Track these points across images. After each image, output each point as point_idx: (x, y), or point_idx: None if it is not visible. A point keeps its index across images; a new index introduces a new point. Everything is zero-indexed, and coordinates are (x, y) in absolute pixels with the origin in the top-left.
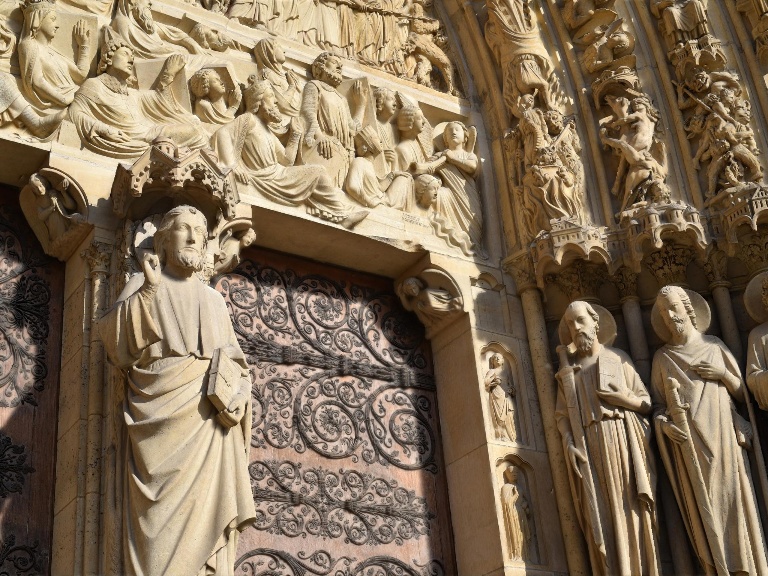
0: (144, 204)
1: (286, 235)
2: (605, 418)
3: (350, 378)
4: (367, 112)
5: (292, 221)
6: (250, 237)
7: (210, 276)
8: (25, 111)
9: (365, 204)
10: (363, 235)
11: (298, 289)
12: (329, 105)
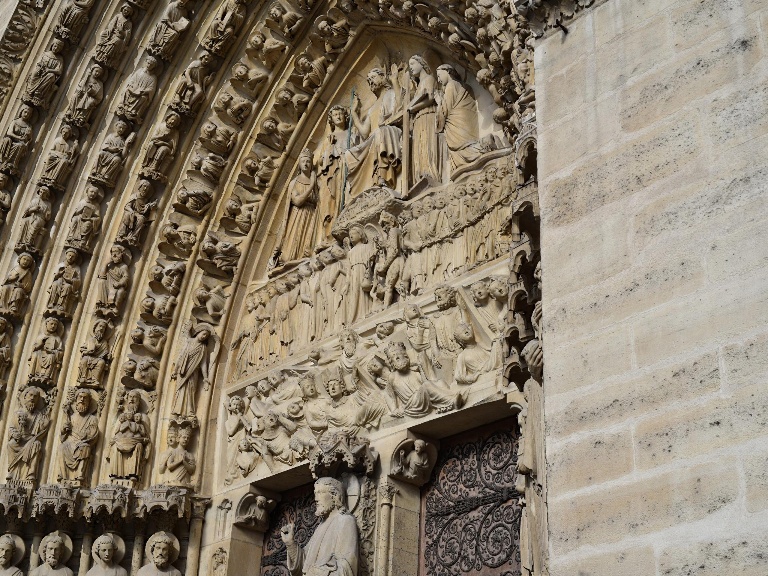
0: (350, 468)
1: (451, 426)
2: (522, 507)
3: (511, 501)
4: (468, 310)
5: (435, 422)
6: (417, 447)
7: (387, 490)
8: (310, 444)
9: (469, 383)
10: (469, 407)
11: (484, 449)
12: (436, 329)
